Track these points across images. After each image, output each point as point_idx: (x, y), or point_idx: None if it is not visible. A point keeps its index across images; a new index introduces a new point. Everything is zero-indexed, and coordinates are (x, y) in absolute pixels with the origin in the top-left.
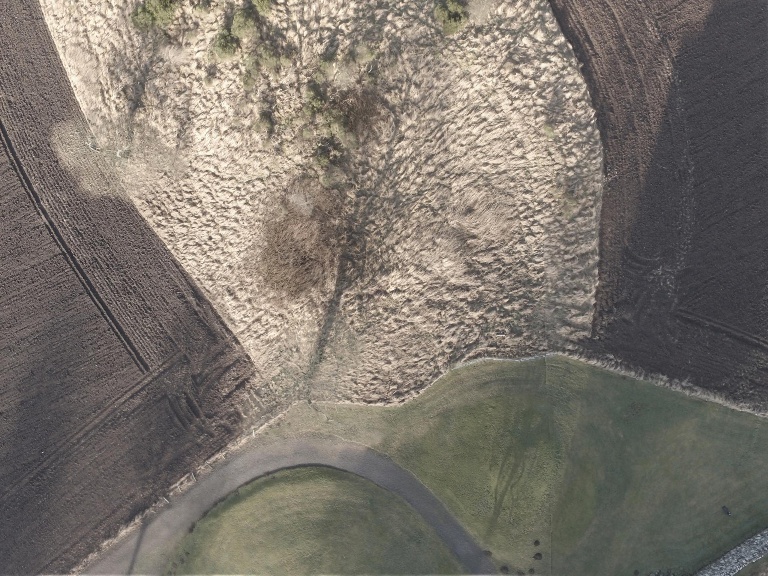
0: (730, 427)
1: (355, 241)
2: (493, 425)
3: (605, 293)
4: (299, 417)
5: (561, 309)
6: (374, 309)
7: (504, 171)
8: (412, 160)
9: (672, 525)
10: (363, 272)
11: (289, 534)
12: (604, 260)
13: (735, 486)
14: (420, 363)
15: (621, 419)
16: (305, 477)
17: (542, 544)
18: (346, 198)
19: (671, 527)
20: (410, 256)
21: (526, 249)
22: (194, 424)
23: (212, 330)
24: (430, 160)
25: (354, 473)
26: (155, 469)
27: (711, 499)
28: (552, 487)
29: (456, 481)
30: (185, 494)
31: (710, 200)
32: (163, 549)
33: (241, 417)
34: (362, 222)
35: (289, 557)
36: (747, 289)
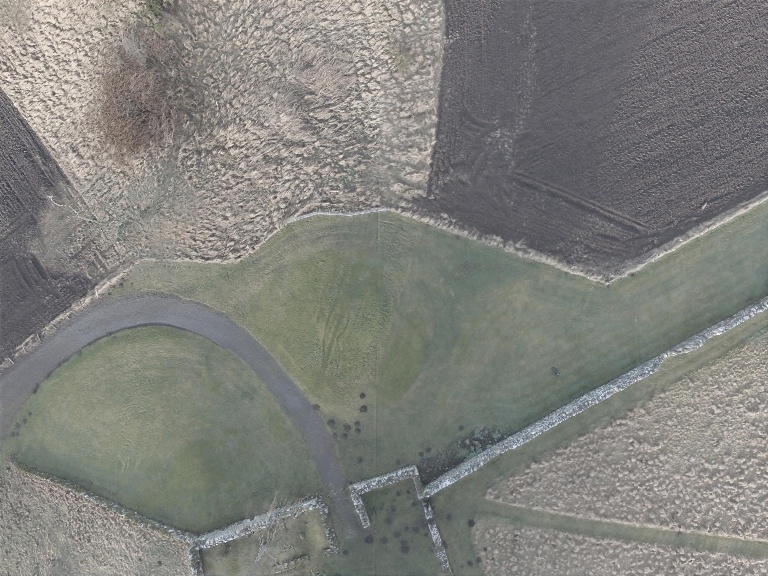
0: (563, 290)
1: (193, 94)
2: (323, 278)
3: (442, 153)
4: (141, 277)
5: (396, 166)
6: (212, 164)
7: (343, 27)
8: (250, 13)
9: (500, 383)
10: (201, 127)
11: (126, 390)
12: (442, 121)
13: (565, 347)
14: (256, 219)
15: (453, 277)
16: (145, 335)
17: (367, 396)
18: (183, 50)
19: (499, 385)
20: (247, 111)
21: (363, 106)
22: (40, 285)
23: (59, 190)
24: (267, 13)
25: (192, 331)
26: (2, 331)
27: (541, 360)
28: (378, 340)
29: (287, 335)
30: (30, 355)
31: (552, 66)
32: (8, 410)
33: (87, 278)
34: (200, 75)
35: (124, 412)
36: (585, 155)
